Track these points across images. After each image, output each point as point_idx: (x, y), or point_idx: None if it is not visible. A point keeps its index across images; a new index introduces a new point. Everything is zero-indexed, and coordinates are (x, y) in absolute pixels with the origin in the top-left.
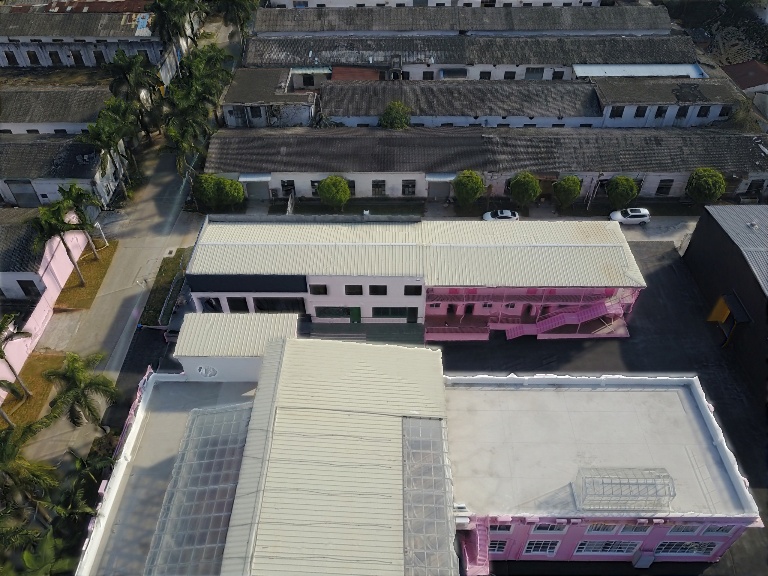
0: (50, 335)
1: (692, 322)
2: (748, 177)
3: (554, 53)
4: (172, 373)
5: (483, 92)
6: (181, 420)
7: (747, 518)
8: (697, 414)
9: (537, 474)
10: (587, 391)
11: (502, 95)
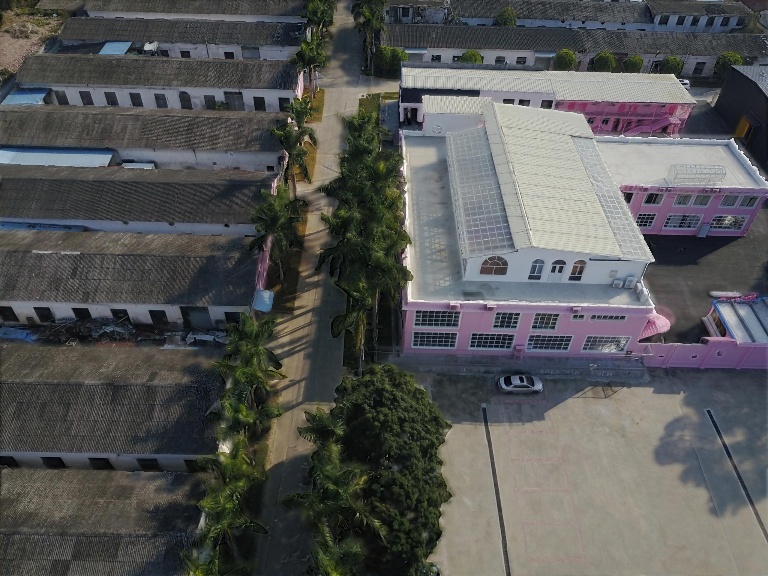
0: None
1: (722, 138)
2: (757, 61)
3: None
4: None
5: (567, 5)
6: (428, 150)
7: (765, 189)
8: (733, 156)
9: (644, 175)
10: (667, 146)
11: (581, 7)
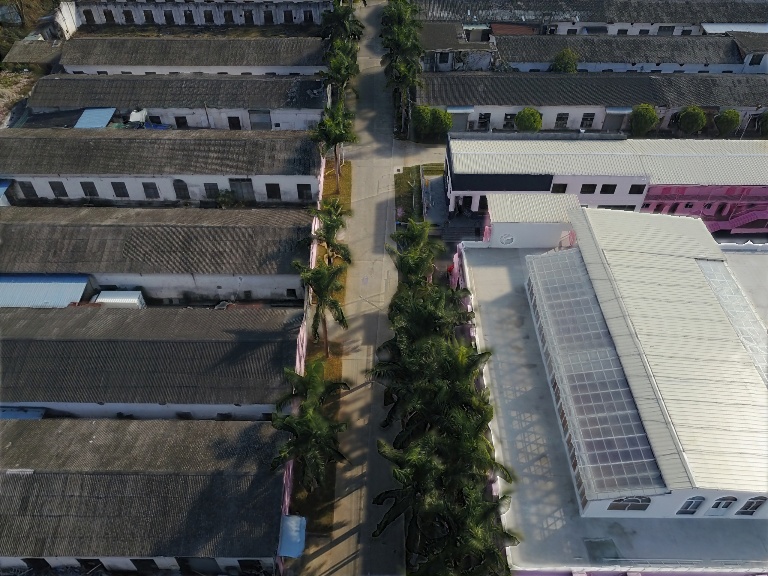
0: None
1: None
2: None
3: (684, 13)
4: (439, 257)
5: (638, 43)
6: (499, 272)
7: None
8: None
9: None
10: None
11: (654, 45)
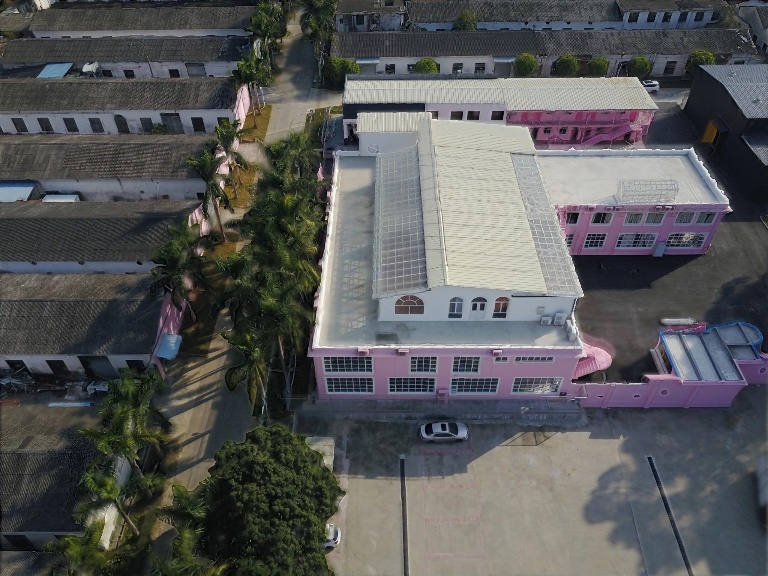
0: (242, 155)
1: (690, 143)
2: (732, 58)
3: None
4: None
5: (531, 5)
6: (362, 172)
7: (722, 204)
8: (692, 167)
9: (592, 192)
10: (621, 158)
11: (546, 7)
